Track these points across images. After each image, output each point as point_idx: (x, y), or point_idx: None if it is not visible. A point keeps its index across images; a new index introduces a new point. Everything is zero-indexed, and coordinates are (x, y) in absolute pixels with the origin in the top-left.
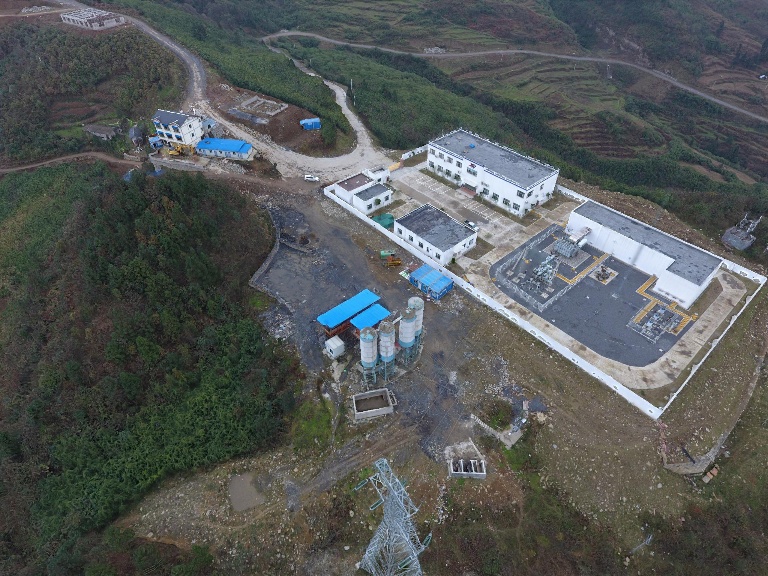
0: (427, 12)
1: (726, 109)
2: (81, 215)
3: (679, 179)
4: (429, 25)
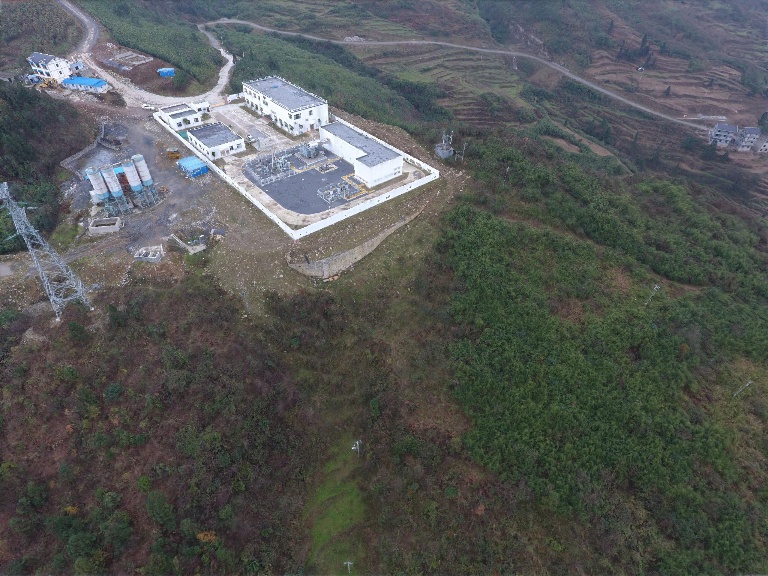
0: (353, 6)
1: (605, 96)
2: None
3: None
4: (353, 17)
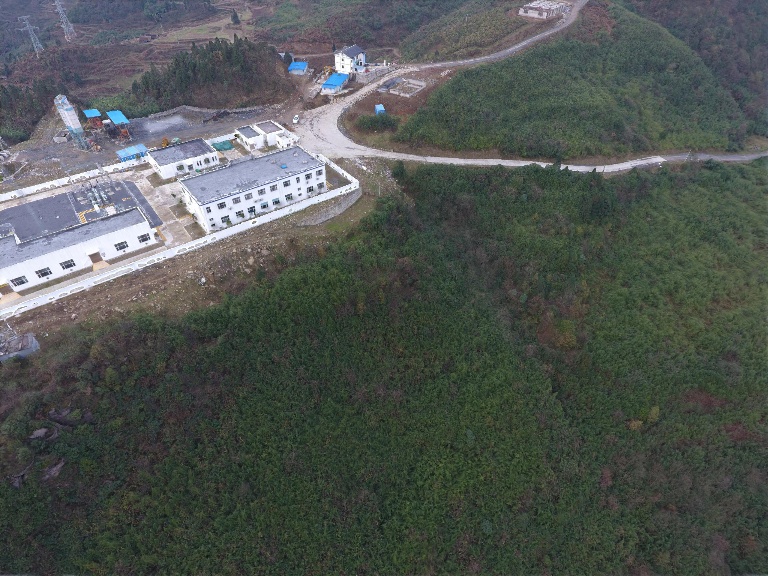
0: None
1: None
2: None
3: None
4: None
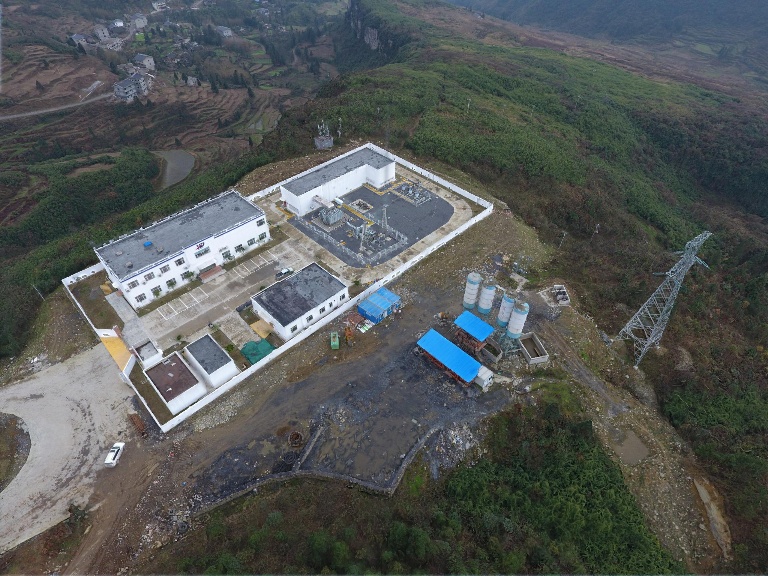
0: None
1: None
2: None
3: (93, 186)
4: None
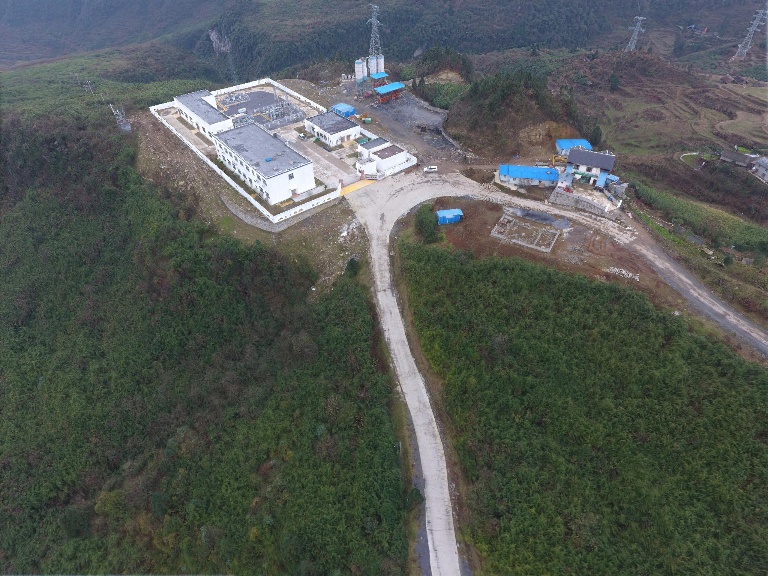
0: None
1: None
2: None
3: None
4: None
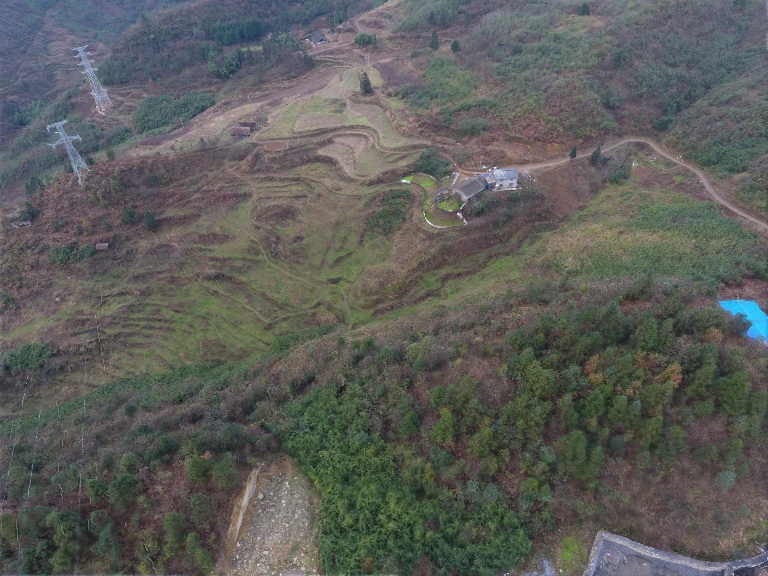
0: None
1: None
2: (620, 289)
3: None
4: None
